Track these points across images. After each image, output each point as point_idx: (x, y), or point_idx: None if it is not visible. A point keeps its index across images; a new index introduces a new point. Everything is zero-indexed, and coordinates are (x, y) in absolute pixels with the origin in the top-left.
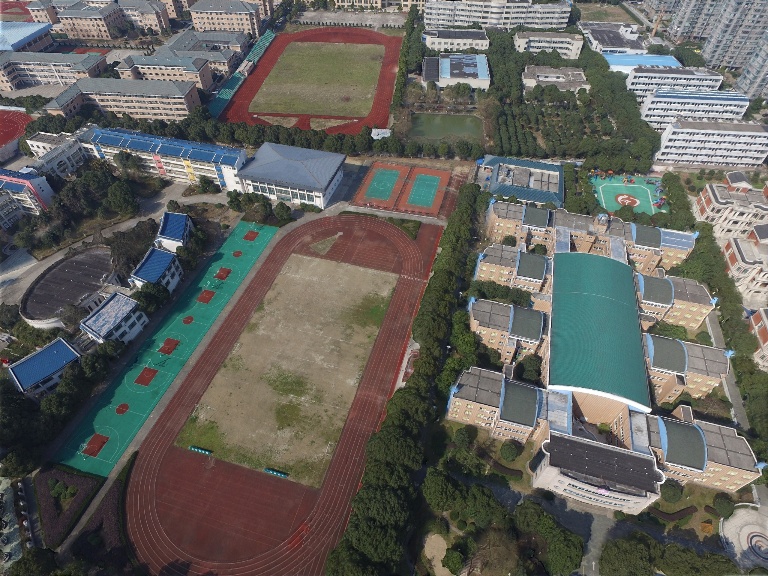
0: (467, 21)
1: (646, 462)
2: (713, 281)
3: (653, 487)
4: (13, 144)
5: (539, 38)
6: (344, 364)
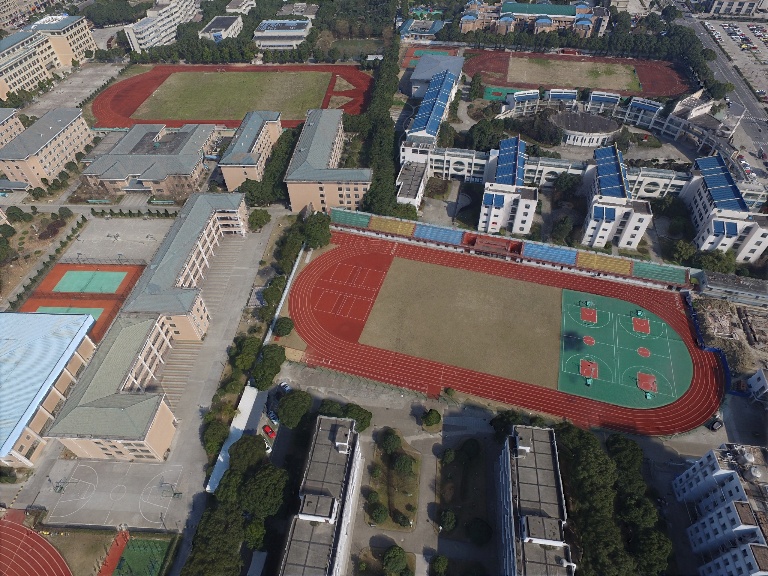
0: (165, 30)
1: (594, 8)
2: (493, 2)
3: (602, 8)
4: (410, 223)
5: (241, 4)
6: (575, 64)
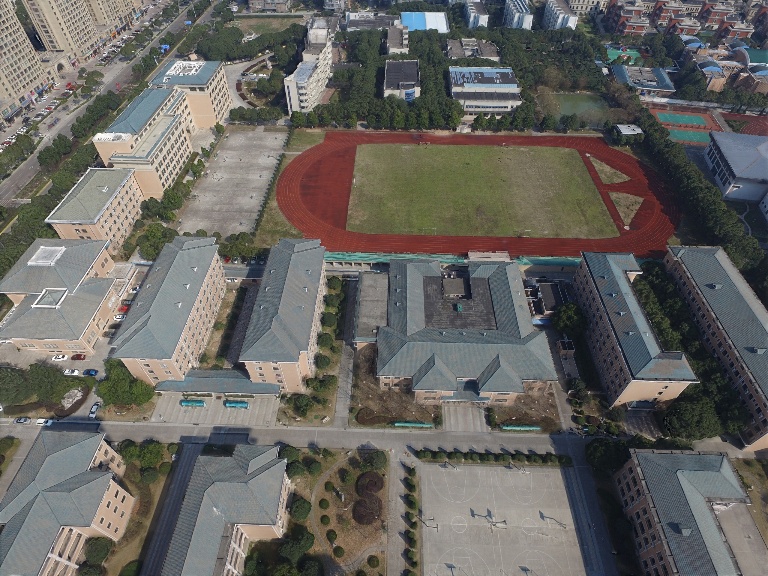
0: None
1: None
2: None
3: None
4: None
5: None
6: None
